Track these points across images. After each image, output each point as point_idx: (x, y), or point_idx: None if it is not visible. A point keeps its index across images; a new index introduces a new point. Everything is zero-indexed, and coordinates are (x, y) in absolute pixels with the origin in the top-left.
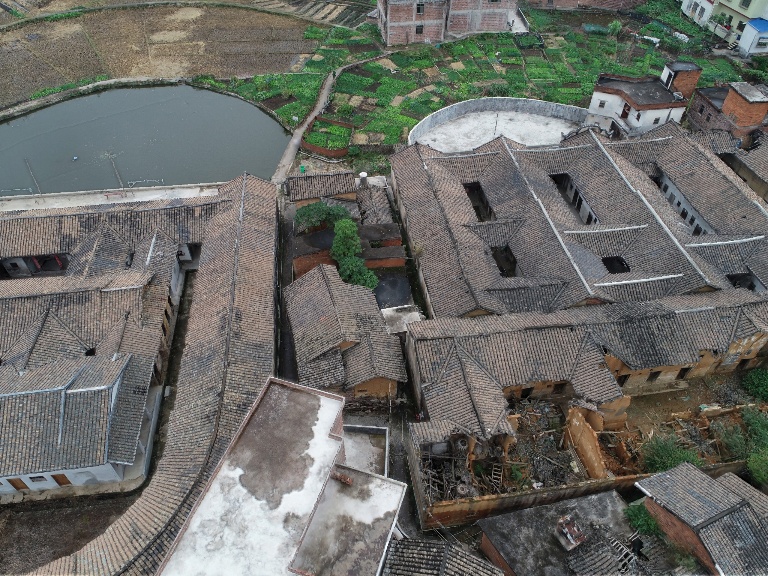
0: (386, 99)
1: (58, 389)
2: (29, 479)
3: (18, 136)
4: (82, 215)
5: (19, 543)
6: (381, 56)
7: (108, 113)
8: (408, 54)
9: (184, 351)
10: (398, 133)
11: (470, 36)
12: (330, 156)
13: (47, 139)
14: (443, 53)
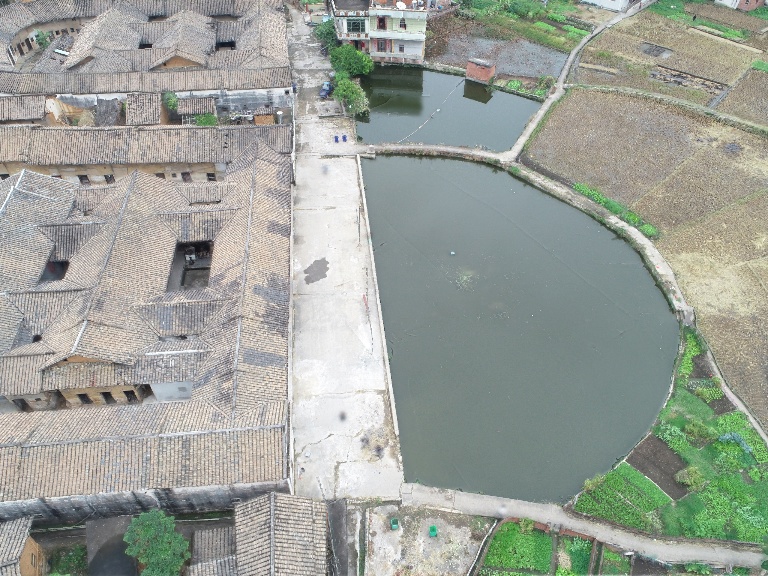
0: None
1: None
2: None
3: (498, 199)
4: None
5: None
6: None
7: (564, 256)
8: None
9: None
10: None
11: None
12: None
13: (491, 221)
14: None
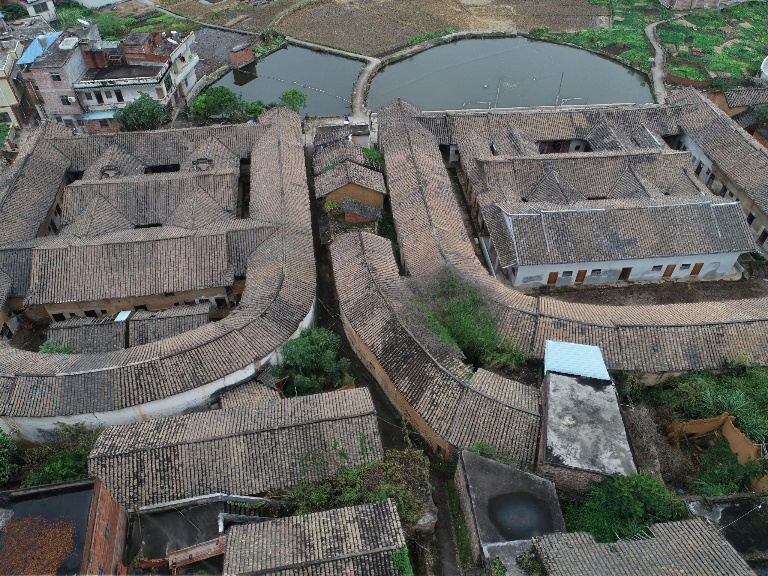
0: (709, 48)
1: (708, 202)
2: (680, 266)
3: (420, 71)
4: (585, 112)
5: (710, 297)
6: (678, 17)
7: (480, 56)
8: (700, 16)
9: (748, 191)
10: (739, 72)
11: (740, 3)
12: (696, 87)
13: (449, 73)
14: (725, 16)
